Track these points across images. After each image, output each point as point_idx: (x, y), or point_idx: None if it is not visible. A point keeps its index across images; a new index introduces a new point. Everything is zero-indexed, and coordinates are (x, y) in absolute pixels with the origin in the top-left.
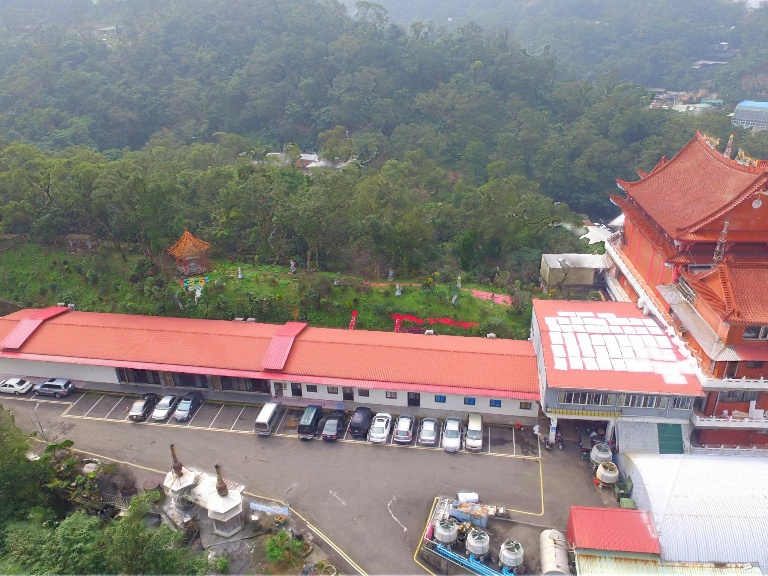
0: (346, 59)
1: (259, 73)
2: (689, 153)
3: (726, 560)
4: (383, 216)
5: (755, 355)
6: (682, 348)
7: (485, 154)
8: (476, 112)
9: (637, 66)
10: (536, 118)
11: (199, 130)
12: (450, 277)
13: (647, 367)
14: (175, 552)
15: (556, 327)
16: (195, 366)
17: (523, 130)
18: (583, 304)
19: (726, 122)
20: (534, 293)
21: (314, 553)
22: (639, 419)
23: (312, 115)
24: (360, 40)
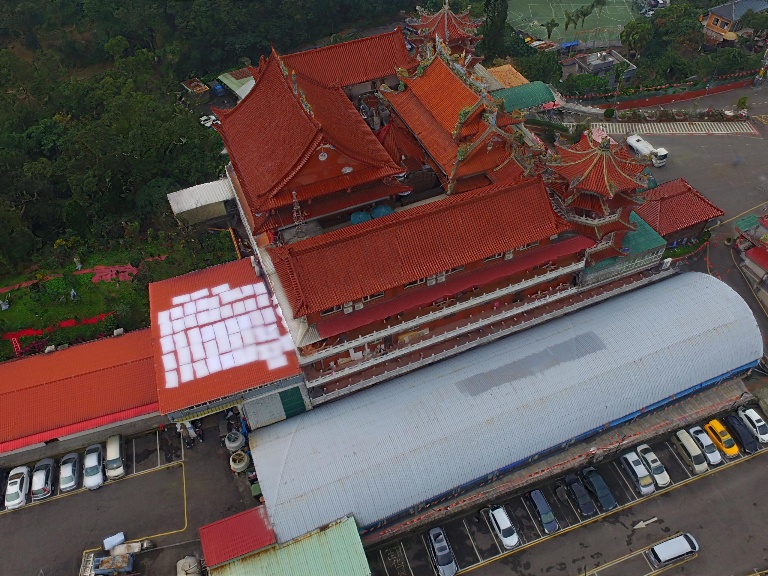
0: None
1: None
2: (270, 76)
3: (328, 522)
4: None
5: (333, 329)
6: (284, 321)
7: (110, 9)
8: None
9: None
10: None
11: None
12: (70, 253)
13: (253, 355)
14: None
15: (167, 328)
16: None
17: None
18: (200, 276)
19: None
20: (166, 247)
21: None
22: (261, 396)
23: None
24: None
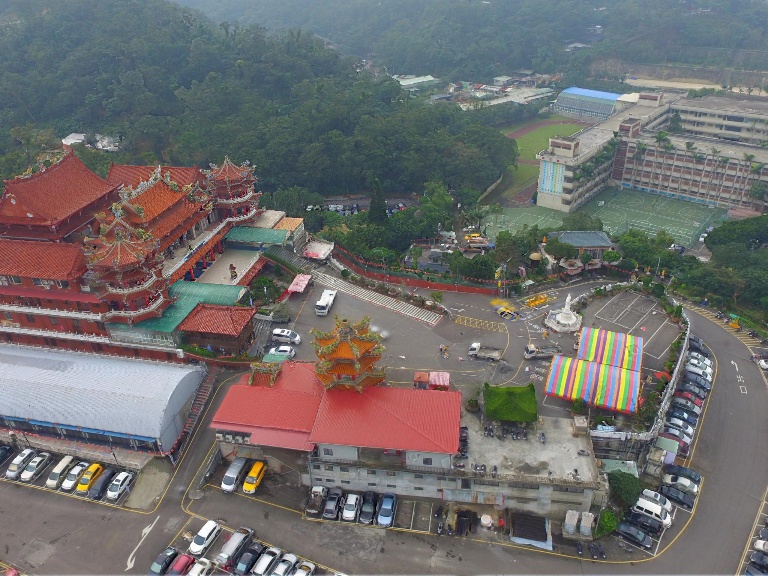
0: (141, 57)
1: None
2: None
3: None
4: None
5: None
6: None
7: None
8: (212, 106)
9: (510, 48)
10: (252, 112)
11: (8, 116)
12: None
13: None
14: None
15: None
16: None
17: (229, 123)
18: None
19: (420, 118)
20: None
21: None
22: None
23: (102, 104)
24: (160, 40)
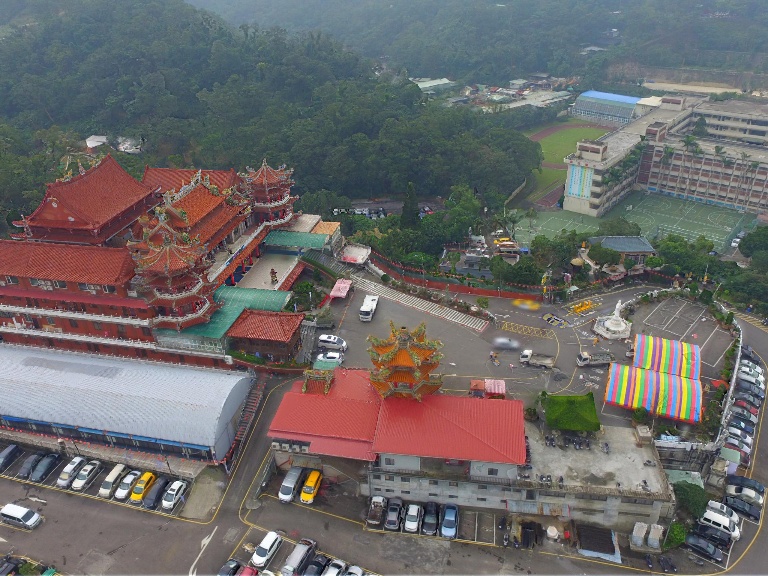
0: (162, 59)
1: (91, 71)
2: None
3: None
4: None
5: None
6: None
7: None
8: (235, 108)
9: (526, 52)
10: (275, 115)
11: (28, 118)
12: None
13: None
14: None
15: None
16: None
17: (252, 126)
18: None
19: (444, 121)
20: None
21: None
22: None
23: (123, 106)
24: (180, 42)
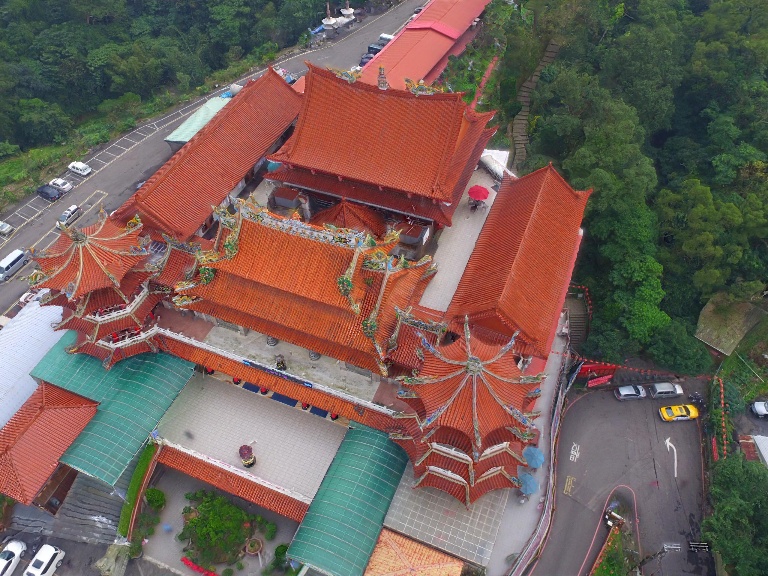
0: None
1: None
2: None
3: None
4: (558, 37)
5: None
6: None
7: None
8: None
9: None
10: None
11: None
12: None
13: None
14: (301, 4)
15: None
16: (428, 7)
17: None
18: None
19: None
20: None
21: (299, 50)
22: None
23: None
24: None
